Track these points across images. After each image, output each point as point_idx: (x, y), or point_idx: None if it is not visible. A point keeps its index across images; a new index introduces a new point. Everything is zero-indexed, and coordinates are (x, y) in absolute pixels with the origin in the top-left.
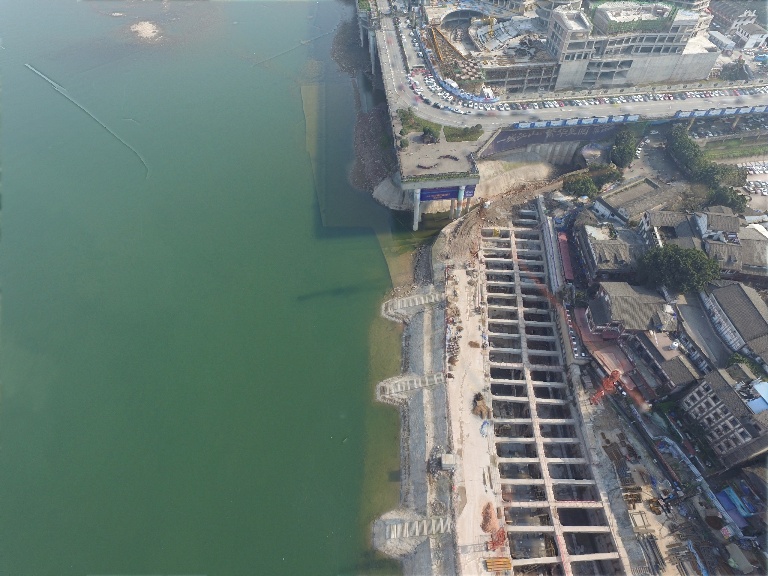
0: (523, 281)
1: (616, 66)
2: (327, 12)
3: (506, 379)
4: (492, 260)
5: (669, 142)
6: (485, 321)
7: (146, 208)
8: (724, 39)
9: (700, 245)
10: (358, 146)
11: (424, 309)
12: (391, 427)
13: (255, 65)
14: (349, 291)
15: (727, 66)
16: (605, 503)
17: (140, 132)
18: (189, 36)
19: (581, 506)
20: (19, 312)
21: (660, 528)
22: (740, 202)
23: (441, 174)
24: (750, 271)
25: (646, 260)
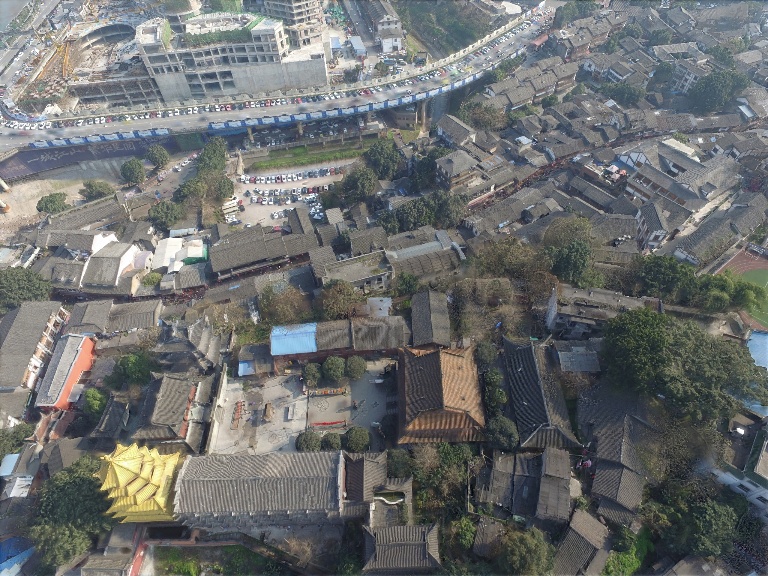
0: None
1: (216, 77)
2: None
3: None
4: None
5: None
6: None
7: None
8: (357, 44)
9: None
10: None
11: None
12: None
13: None
14: None
15: (349, 72)
16: None
17: None
18: None
19: None
20: None
21: None
22: (162, 216)
23: None
24: (91, 289)
25: None
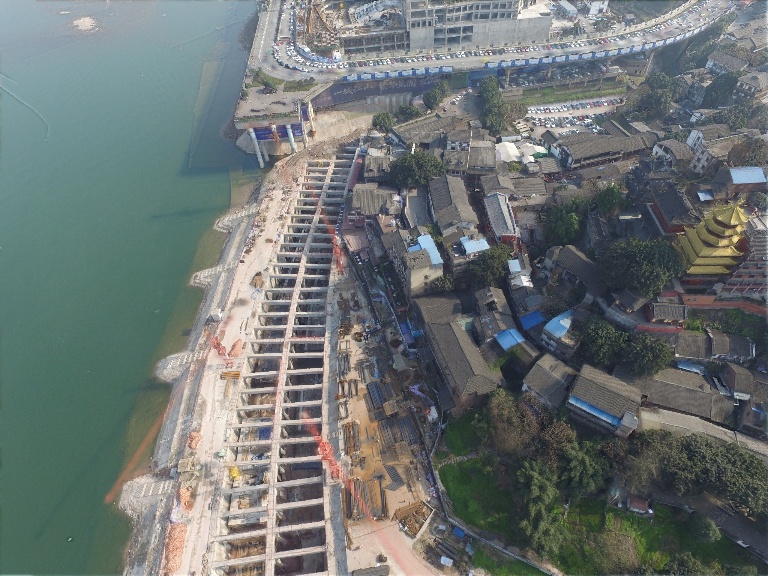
0: None
1: (460, 32)
2: (250, 4)
3: (285, 263)
4: (308, 183)
5: None
6: (284, 225)
7: (37, 152)
8: (569, 7)
9: (440, 154)
10: None
11: (243, 220)
12: (195, 302)
13: (171, 48)
14: (193, 212)
15: (566, 29)
16: (327, 338)
17: (48, 99)
18: (121, 27)
19: (308, 340)
20: None
21: (357, 350)
22: (496, 125)
23: (266, 115)
24: (475, 171)
25: (390, 164)
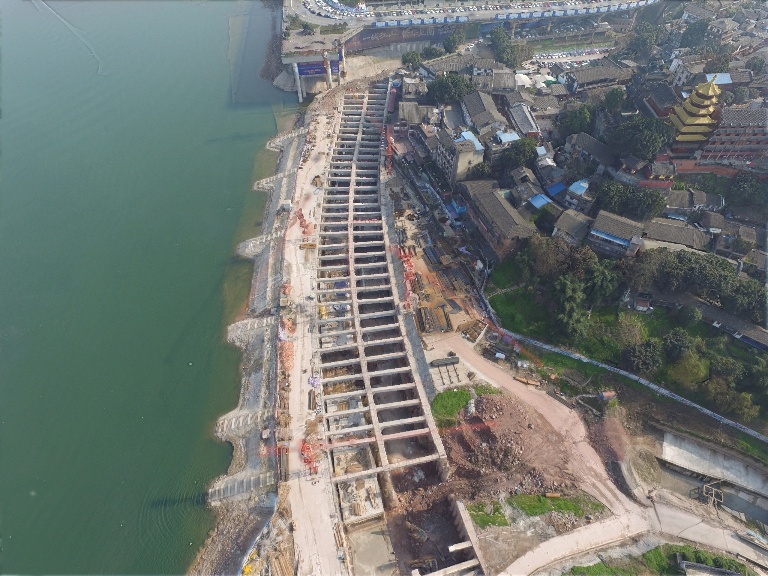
0: (371, 127)
1: None
2: None
3: None
4: (347, 111)
5: (491, 37)
6: (333, 142)
7: (96, 83)
8: None
9: (469, 78)
10: (267, 54)
11: (294, 140)
12: (261, 202)
13: (194, 5)
14: (245, 136)
15: None
16: (384, 221)
17: (94, 40)
18: None
19: (368, 222)
20: (3, 152)
21: (411, 226)
22: (512, 60)
23: (309, 51)
24: (498, 92)
25: (428, 85)
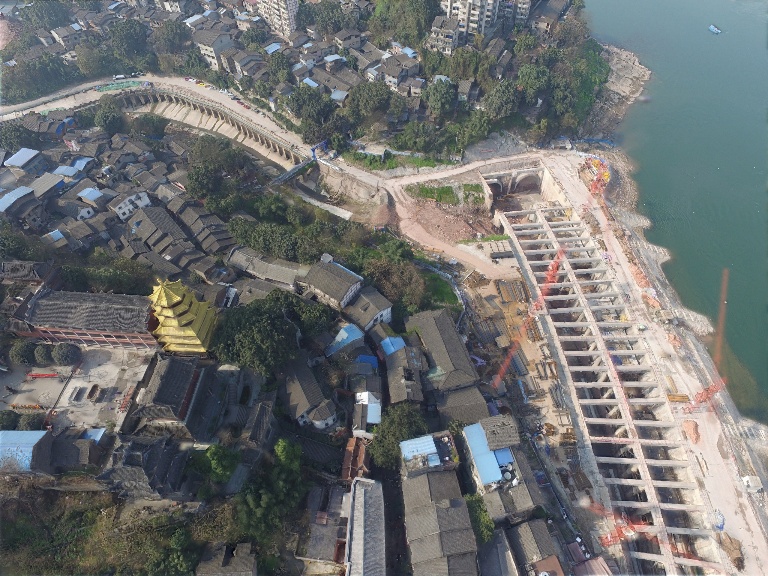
0: None
1: None
2: None
3: None
4: None
5: None
6: None
7: None
8: None
9: None
10: None
11: None
12: None
13: None
14: None
15: None
16: (588, 439)
17: None
18: None
19: (610, 438)
20: None
21: (548, 413)
22: None
23: None
24: None
25: None
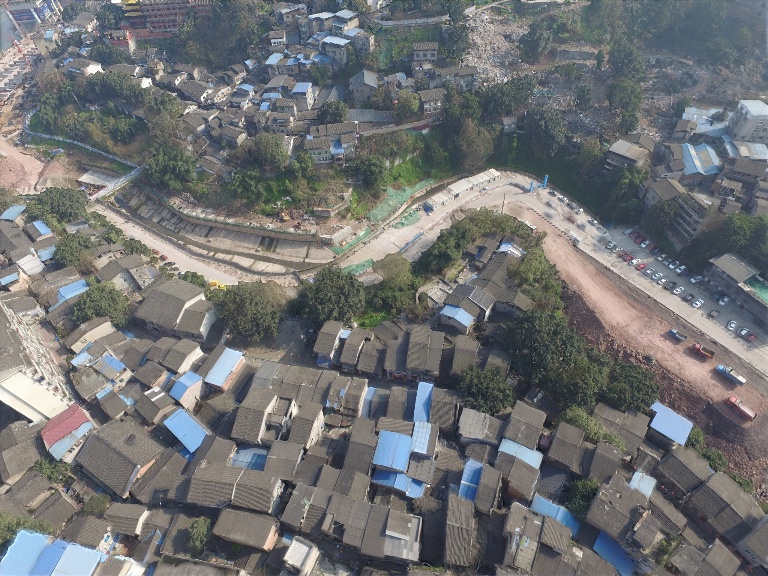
0: None
1: None
2: None
3: None
4: None
5: None
6: (15, 57)
7: None
8: None
9: None
10: None
11: None
12: None
13: None
14: None
15: None
16: None
17: None
18: None
19: (0, 94)
20: None
21: (21, 92)
22: None
23: (15, 2)
24: None
25: None
